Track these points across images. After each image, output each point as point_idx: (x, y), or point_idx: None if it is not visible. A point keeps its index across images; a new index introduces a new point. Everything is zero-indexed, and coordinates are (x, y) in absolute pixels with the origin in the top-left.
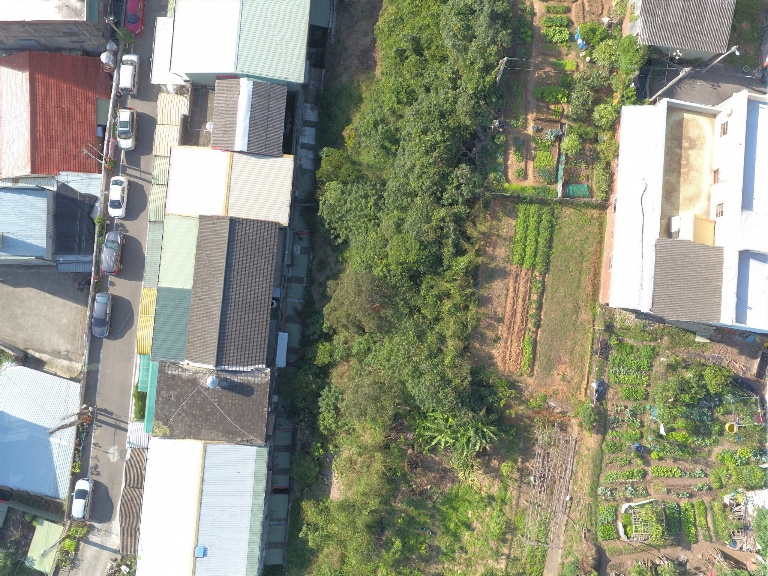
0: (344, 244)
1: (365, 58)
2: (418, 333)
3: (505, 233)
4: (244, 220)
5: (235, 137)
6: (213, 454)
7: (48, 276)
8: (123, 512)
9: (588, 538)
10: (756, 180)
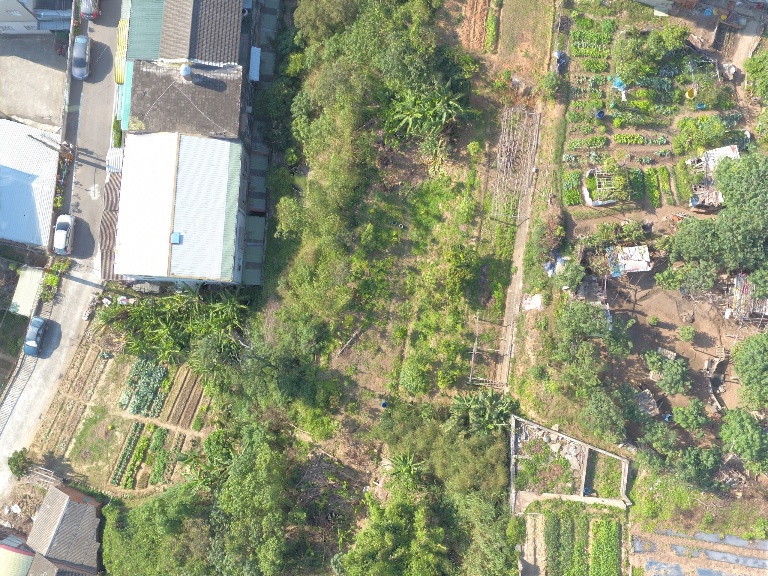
0: None
1: None
2: (383, 11)
3: None
4: None
5: None
6: (187, 145)
7: (31, 45)
8: (103, 233)
9: (554, 203)
10: None
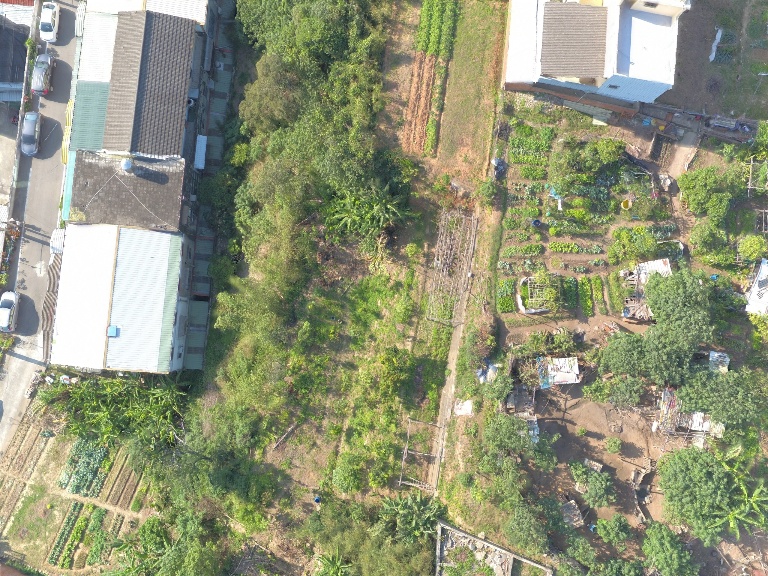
0: (263, 54)
1: None
2: (324, 113)
3: (410, 22)
4: (161, 14)
5: None
6: (127, 238)
7: None
8: (45, 315)
9: (487, 310)
10: None
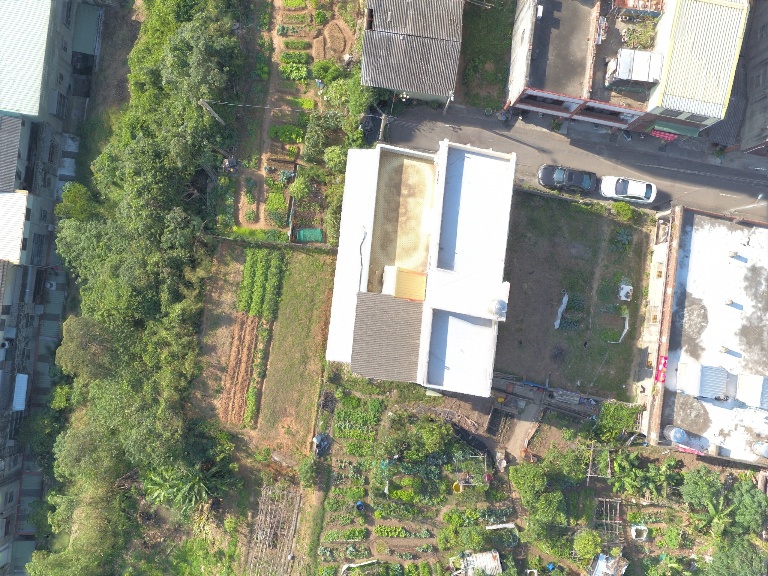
0: None
1: (122, 88)
2: (134, 382)
3: (232, 278)
4: None
5: None
6: None
7: None
8: None
9: None
10: (459, 233)
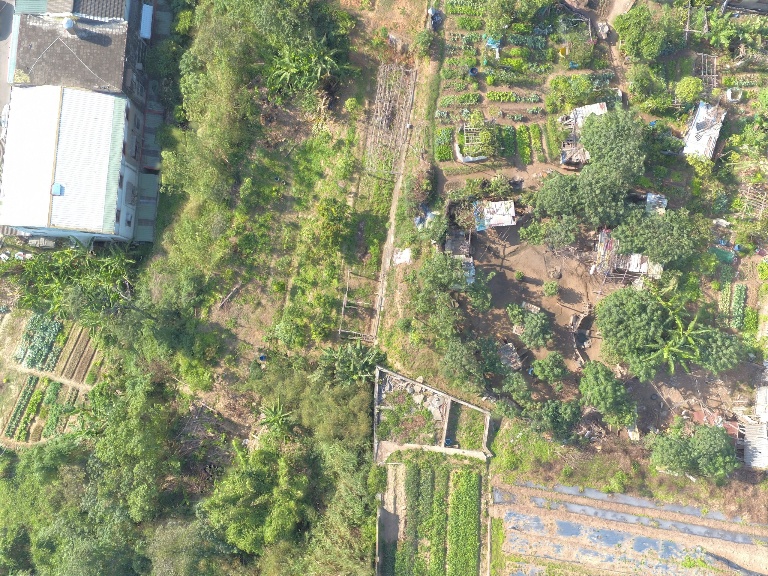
0: None
1: None
2: None
3: None
4: None
5: None
6: (71, 98)
7: None
8: None
9: (425, 158)
10: None
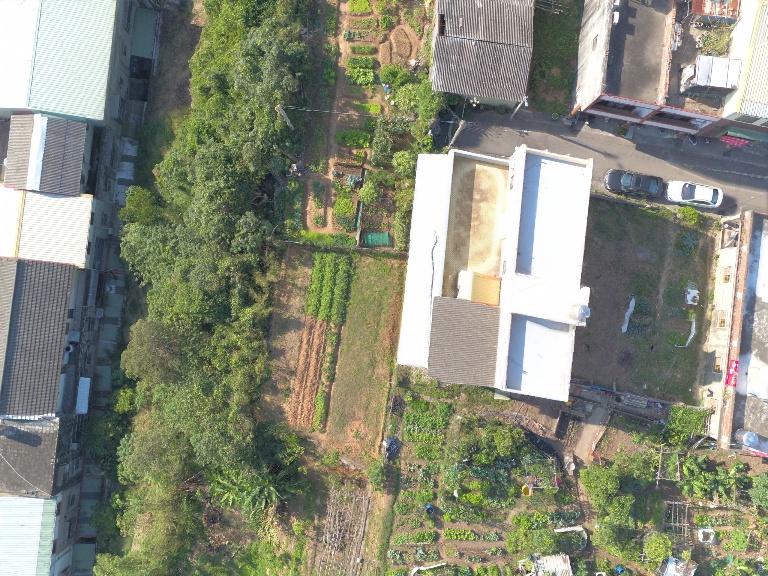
0: None
1: (182, 93)
2: (204, 386)
3: (300, 282)
4: (34, 262)
5: (27, 175)
6: None
7: None
8: None
9: None
10: (535, 238)
